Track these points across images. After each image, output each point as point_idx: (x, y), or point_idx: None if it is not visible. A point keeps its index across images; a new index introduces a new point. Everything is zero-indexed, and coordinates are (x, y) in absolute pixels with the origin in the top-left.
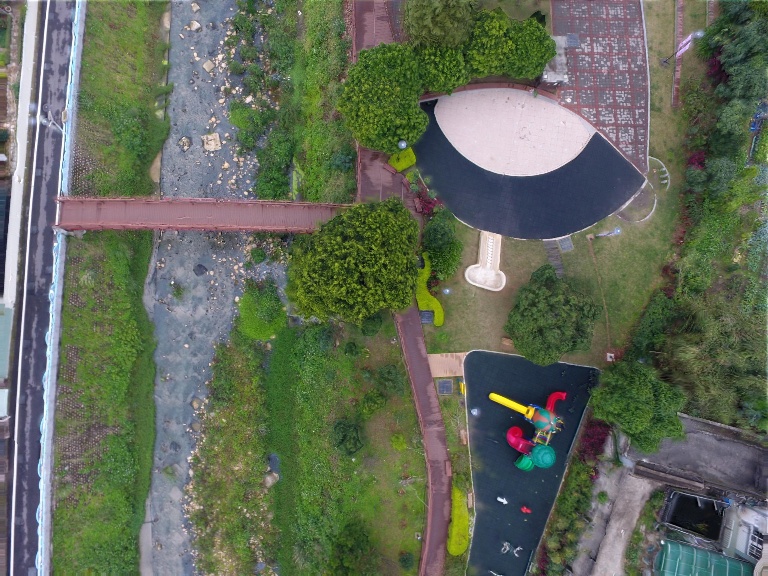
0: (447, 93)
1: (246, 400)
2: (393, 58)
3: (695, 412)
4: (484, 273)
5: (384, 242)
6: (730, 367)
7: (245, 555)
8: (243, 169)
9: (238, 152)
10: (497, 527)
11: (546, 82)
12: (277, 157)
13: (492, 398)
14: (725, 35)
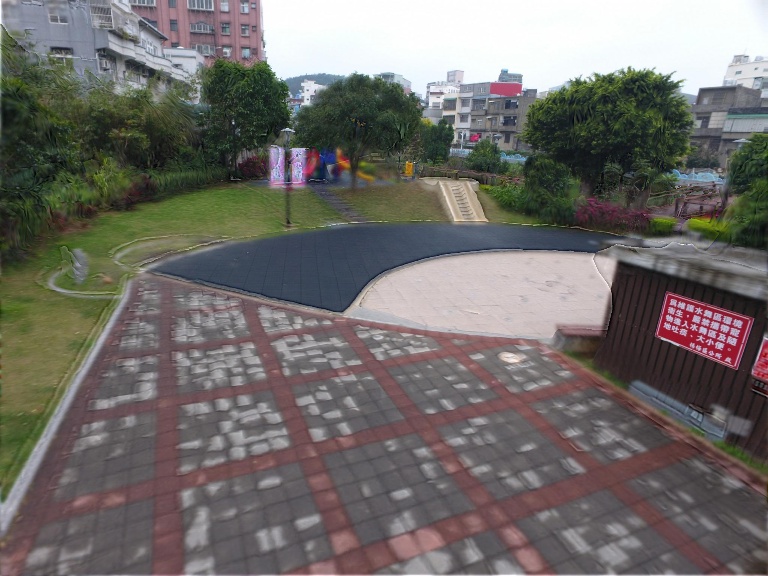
0: None
1: None
2: None
3: None
4: None
5: None
6: None
7: None
8: None
9: None
10: None
11: None
12: None
13: None
14: None
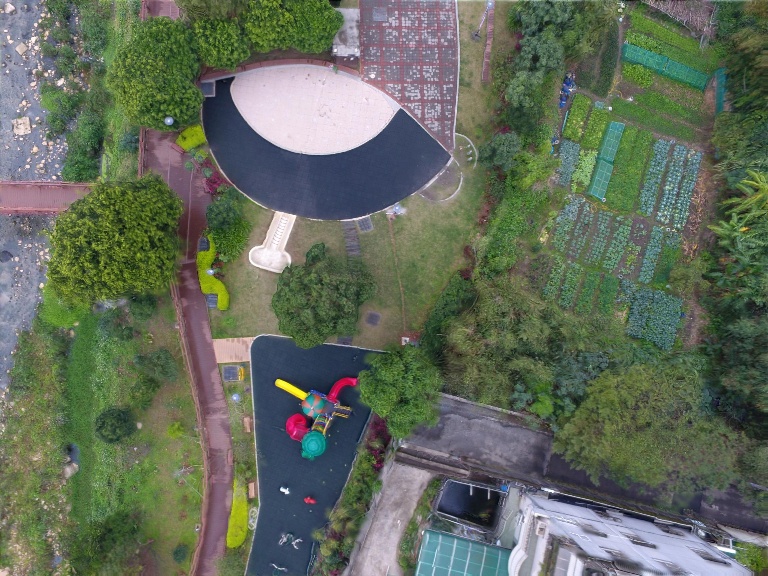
0: (243, 70)
1: (46, 389)
2: (160, 32)
3: (473, 396)
4: (269, 254)
5: (121, 219)
6: (509, 349)
7: (39, 548)
8: (53, 153)
9: (47, 136)
10: (281, 518)
11: (338, 56)
12: (81, 140)
13: (277, 384)
14: (527, 5)
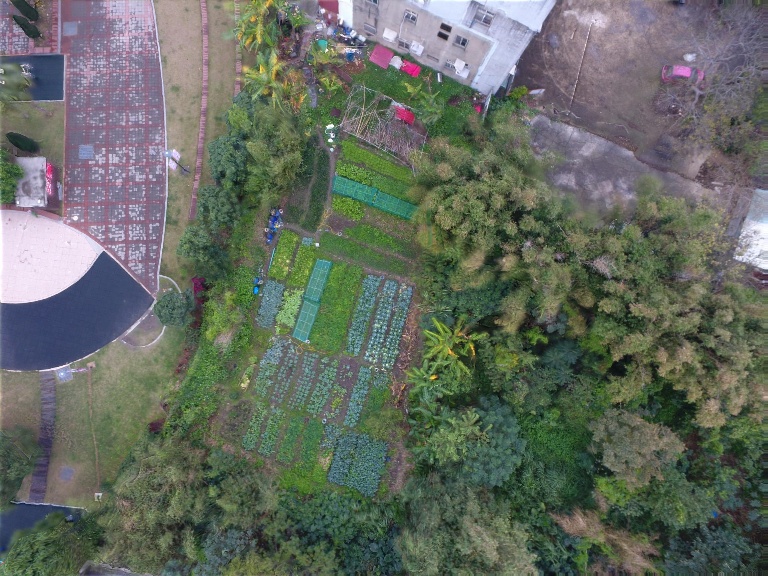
0: None
1: None
2: None
3: None
4: None
5: None
6: None
7: None
8: None
9: None
10: None
11: (24, 207)
12: None
13: None
14: None
